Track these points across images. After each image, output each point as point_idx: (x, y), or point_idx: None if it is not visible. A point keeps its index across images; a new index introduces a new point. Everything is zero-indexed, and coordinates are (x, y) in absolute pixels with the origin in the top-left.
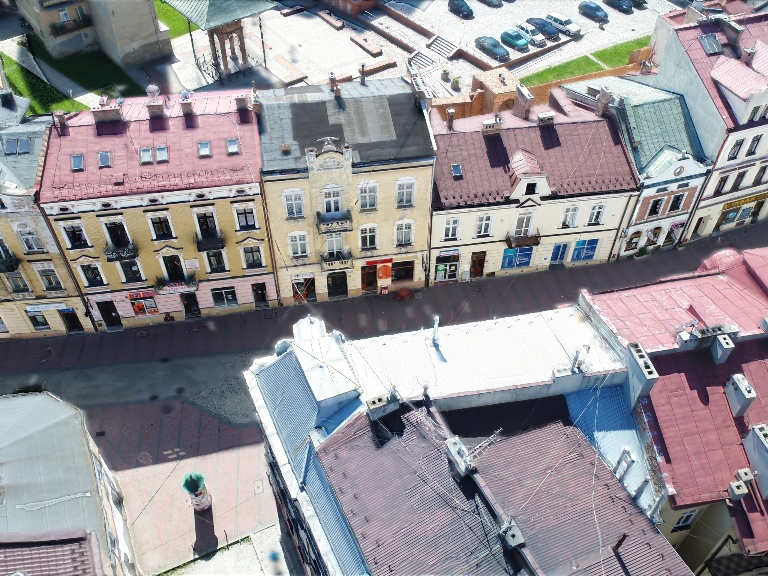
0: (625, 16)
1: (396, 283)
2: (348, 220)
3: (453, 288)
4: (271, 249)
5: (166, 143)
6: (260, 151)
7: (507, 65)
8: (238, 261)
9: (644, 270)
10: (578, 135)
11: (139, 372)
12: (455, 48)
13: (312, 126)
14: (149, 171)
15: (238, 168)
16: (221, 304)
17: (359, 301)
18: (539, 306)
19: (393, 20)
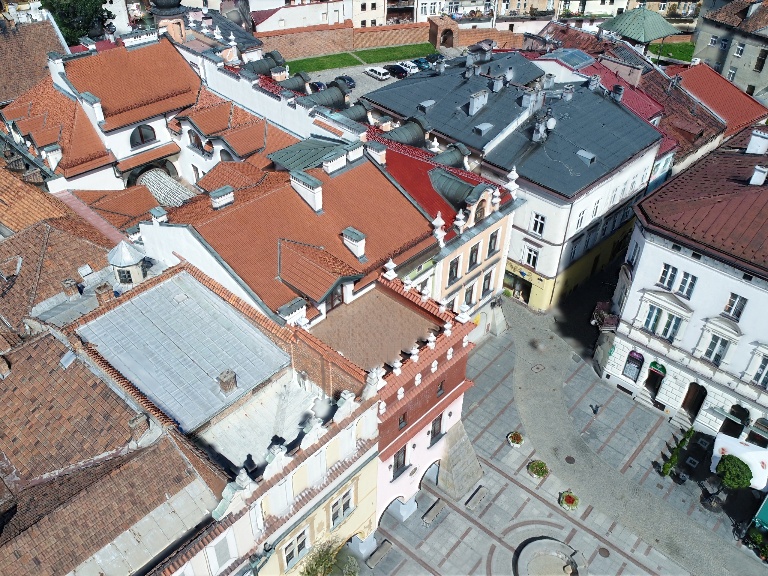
0: None
1: None
2: None
3: None
4: None
5: None
6: None
7: None
8: None
9: None
10: None
11: None
12: None
13: None
14: None
15: None
16: None
17: None
18: None
19: None
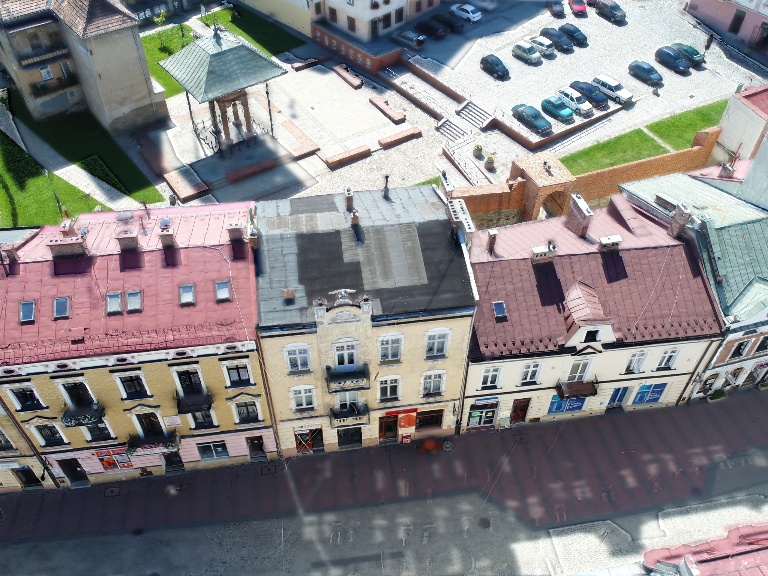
0: (682, 78)
1: (420, 431)
2: (365, 378)
3: (489, 437)
4: (269, 403)
5: (139, 286)
6: (256, 300)
7: (549, 139)
8: (229, 416)
9: (720, 417)
10: (648, 264)
11: (105, 549)
12: (489, 117)
13: (322, 265)
14: (117, 324)
15: (228, 320)
16: (209, 456)
17: (375, 452)
18: (594, 466)
19: (418, 78)
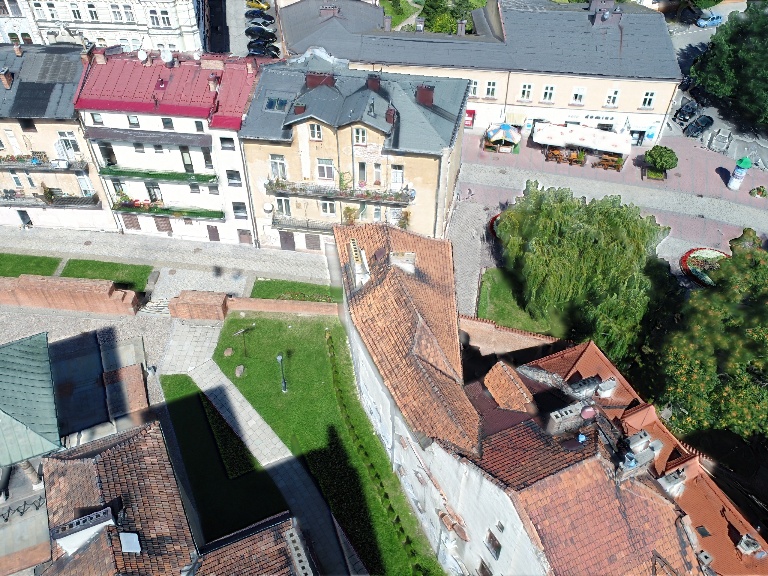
0: None
1: None
2: None
3: None
4: None
5: None
6: None
7: None
8: None
9: None
10: None
11: None
12: None
13: None
14: None
15: None
16: None
17: None
18: None
19: None
